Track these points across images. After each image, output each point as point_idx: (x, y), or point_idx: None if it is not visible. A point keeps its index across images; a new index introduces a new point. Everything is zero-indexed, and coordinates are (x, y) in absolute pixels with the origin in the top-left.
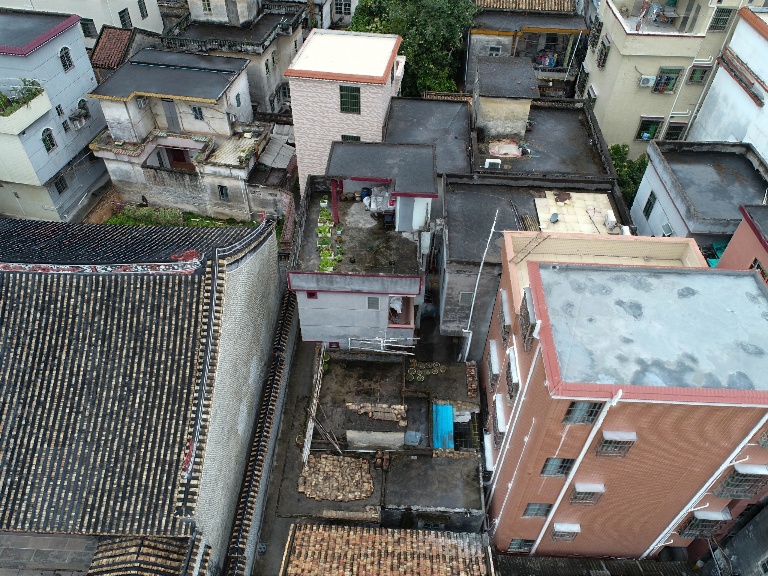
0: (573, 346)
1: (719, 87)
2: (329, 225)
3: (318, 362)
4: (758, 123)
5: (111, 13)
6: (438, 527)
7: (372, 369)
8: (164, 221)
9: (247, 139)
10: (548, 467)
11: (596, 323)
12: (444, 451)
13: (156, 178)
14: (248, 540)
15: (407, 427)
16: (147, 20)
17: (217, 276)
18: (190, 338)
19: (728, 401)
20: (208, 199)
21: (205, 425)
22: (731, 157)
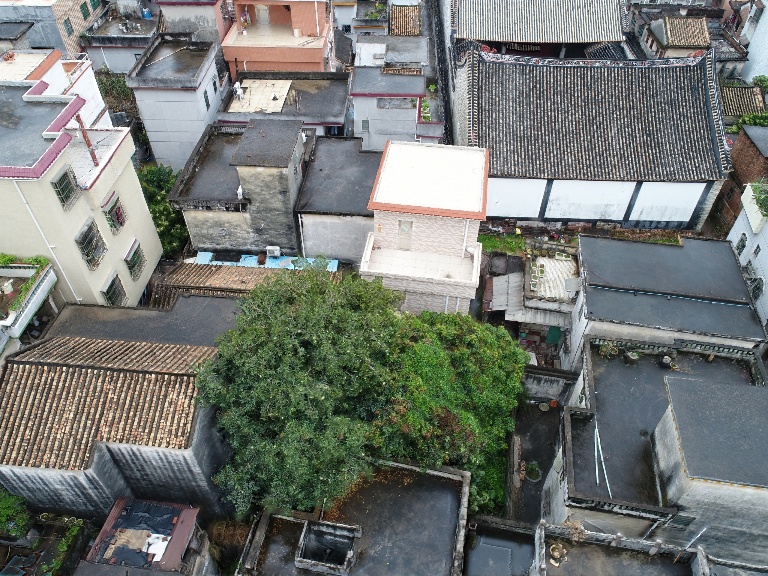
0: None
1: None
2: None
3: None
4: None
5: None
6: None
7: None
8: None
9: None
10: None
11: None
12: None
13: None
14: None
15: None
16: None
17: None
18: None
19: None
20: None
21: None
22: None
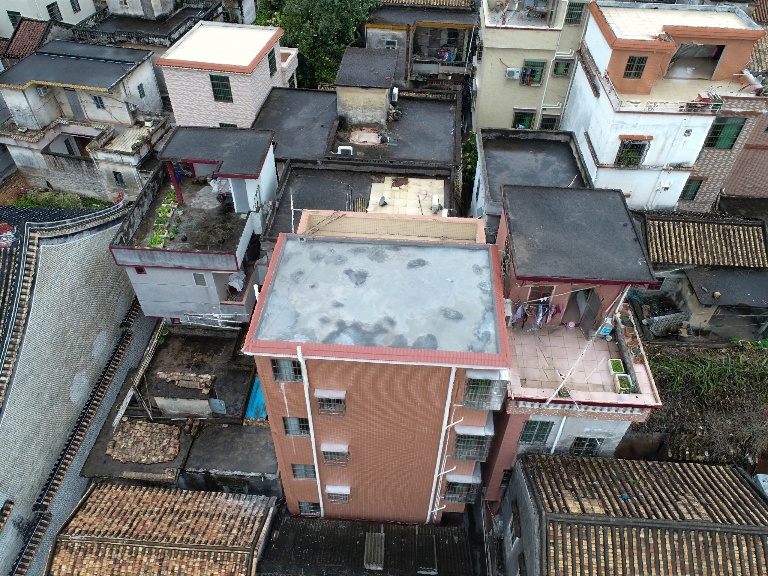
0: (284, 309)
1: (578, 79)
2: (172, 206)
3: (154, 336)
4: (596, 113)
5: (38, 6)
6: (243, 492)
7: (209, 344)
8: (64, 206)
9: (147, 128)
10: (289, 426)
11: (317, 289)
12: (255, 420)
13: (56, 164)
14: (61, 500)
15: (212, 395)
16: (80, 14)
17: (27, 248)
18: (5, 307)
19: (405, 359)
20: (106, 185)
21: (2, 386)
22: (556, 145)
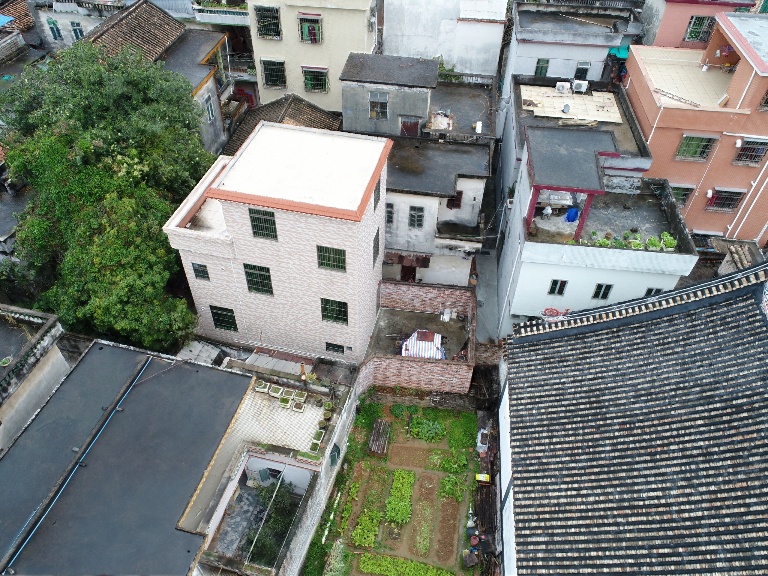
0: None
1: None
2: None
3: None
4: None
5: None
6: None
7: None
8: None
9: None
10: None
11: None
12: None
13: (284, 568)
14: None
15: None
16: None
17: None
18: None
19: None
20: (322, 492)
21: None
22: (518, 15)
